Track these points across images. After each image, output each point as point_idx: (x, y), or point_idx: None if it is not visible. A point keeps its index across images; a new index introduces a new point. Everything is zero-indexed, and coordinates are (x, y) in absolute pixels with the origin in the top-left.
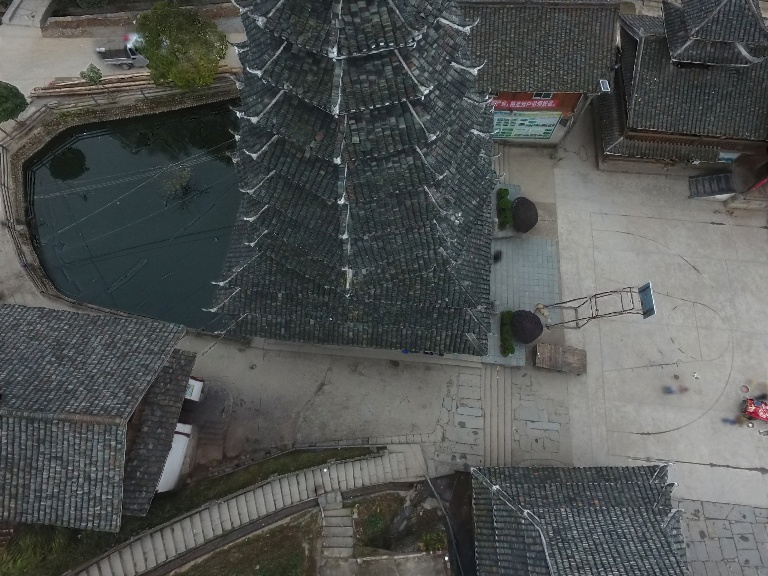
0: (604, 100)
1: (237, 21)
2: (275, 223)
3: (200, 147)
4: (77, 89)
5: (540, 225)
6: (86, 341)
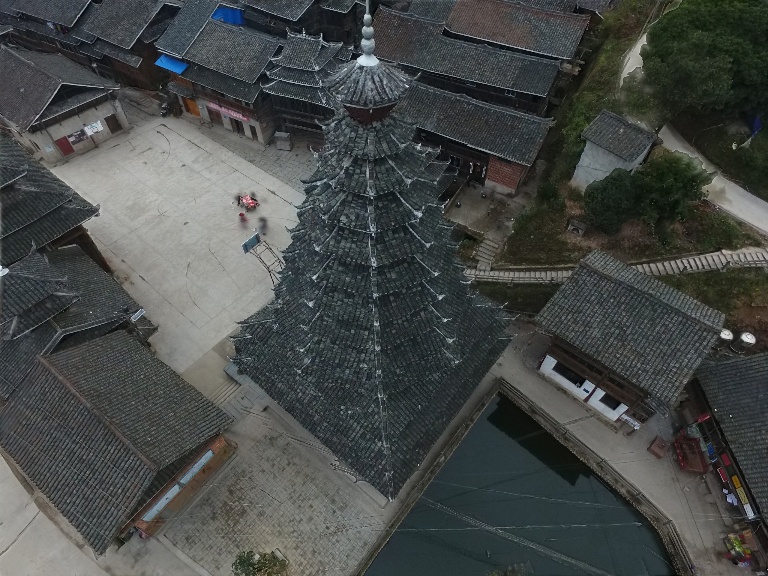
0: None
1: None
2: None
3: None
4: None
5: None
6: (603, 336)
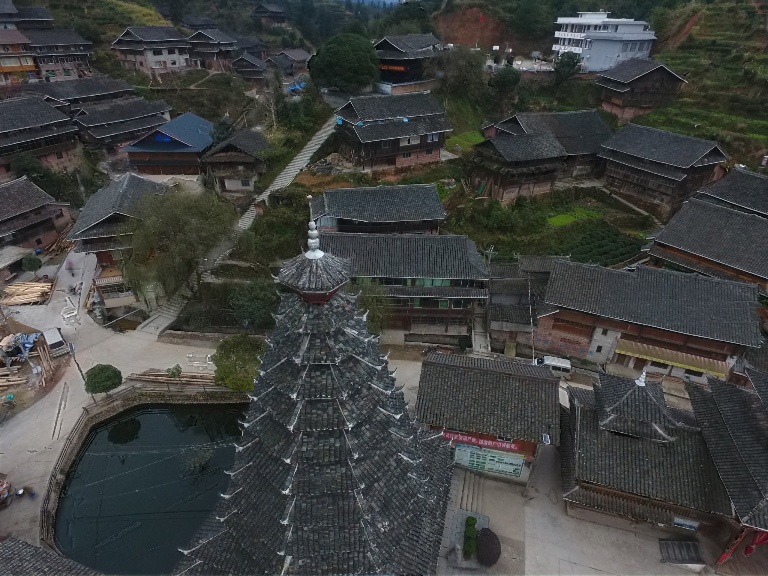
0: (563, 451)
1: None
2: (243, 503)
3: (231, 435)
4: (160, 378)
5: (507, 562)
6: None
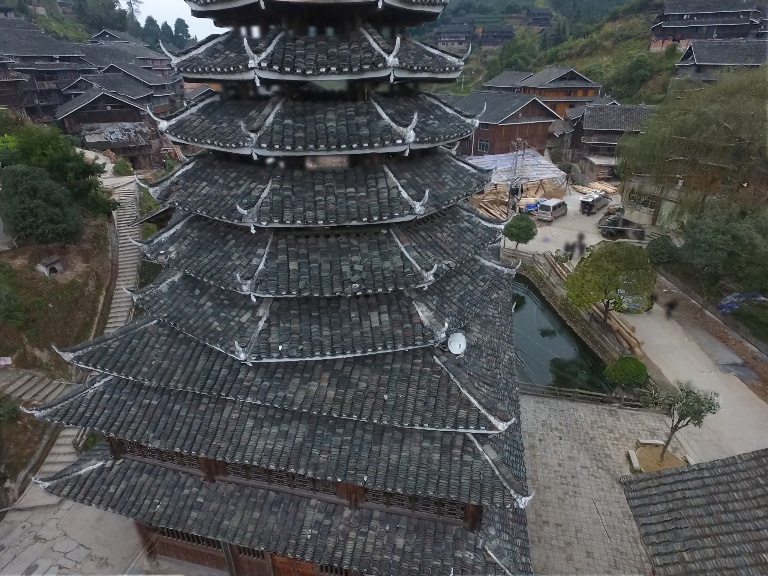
0: None
1: (730, 355)
2: None
3: (553, 371)
4: None
5: None
6: None
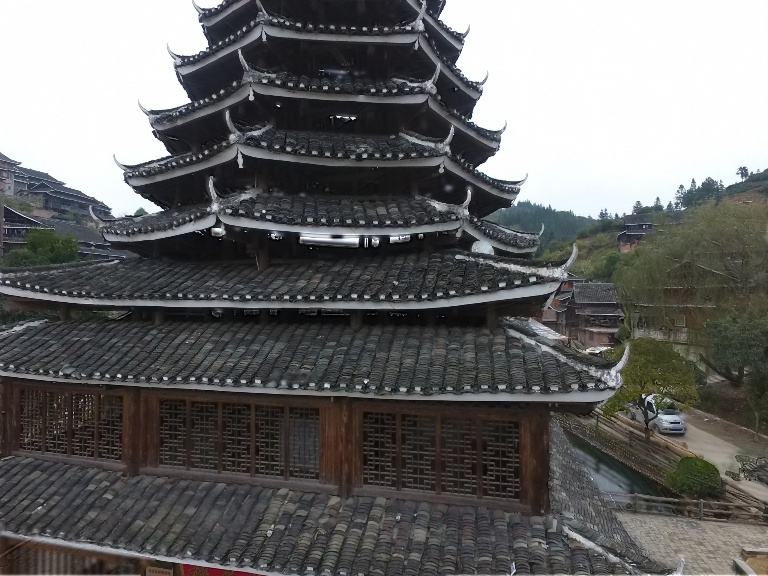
0: None
1: None
2: None
3: None
4: None
5: None
6: None
